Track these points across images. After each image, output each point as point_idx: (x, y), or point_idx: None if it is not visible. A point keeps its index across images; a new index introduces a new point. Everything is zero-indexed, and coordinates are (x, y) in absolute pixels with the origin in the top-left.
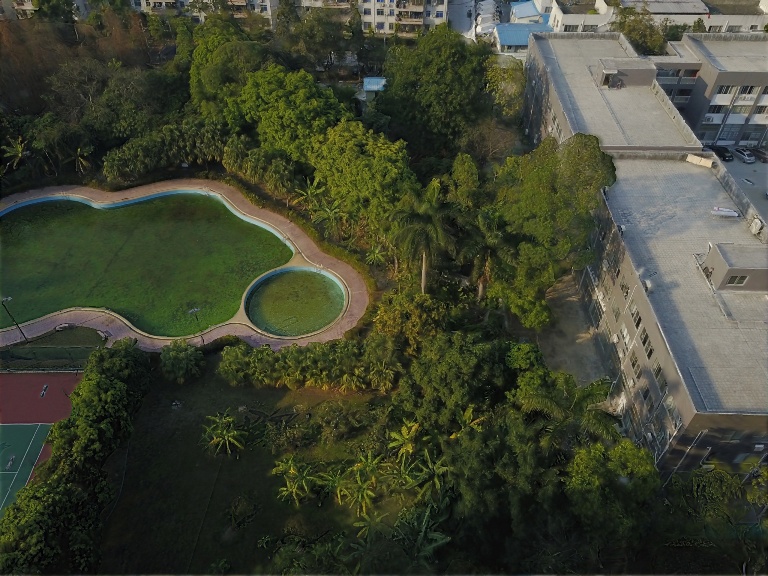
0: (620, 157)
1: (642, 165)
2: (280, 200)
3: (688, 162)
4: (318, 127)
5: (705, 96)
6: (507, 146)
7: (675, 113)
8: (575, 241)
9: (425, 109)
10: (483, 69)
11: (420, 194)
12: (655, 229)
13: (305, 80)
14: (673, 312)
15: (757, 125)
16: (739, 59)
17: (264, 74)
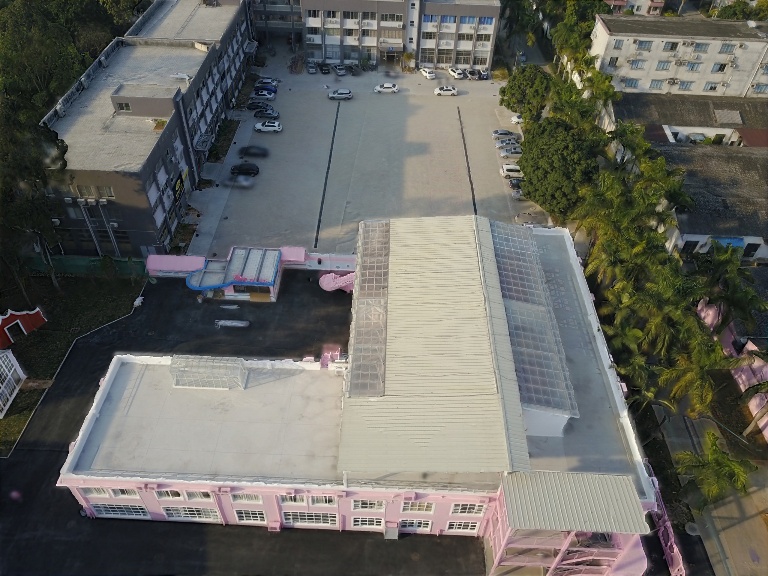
0: (146, 44)
1: (160, 49)
2: None
3: (197, 49)
4: None
5: None
6: None
7: None
8: (50, 88)
9: (54, 17)
10: None
11: None
12: None
13: None
14: (70, 126)
15: (352, 46)
16: None
17: None
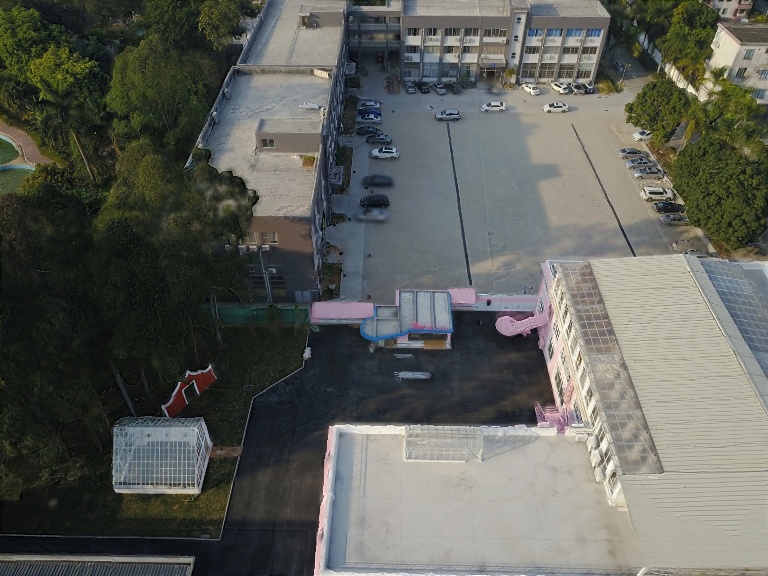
0: (262, 72)
1: (277, 78)
2: (29, 120)
3: (316, 75)
4: (35, 53)
5: (401, 38)
6: (211, 74)
7: (339, 44)
8: (180, 125)
9: None
10: (199, 12)
11: (51, 86)
12: (249, 117)
13: (32, 17)
14: (214, 165)
15: (451, 63)
16: (435, 8)
17: (2, 13)
